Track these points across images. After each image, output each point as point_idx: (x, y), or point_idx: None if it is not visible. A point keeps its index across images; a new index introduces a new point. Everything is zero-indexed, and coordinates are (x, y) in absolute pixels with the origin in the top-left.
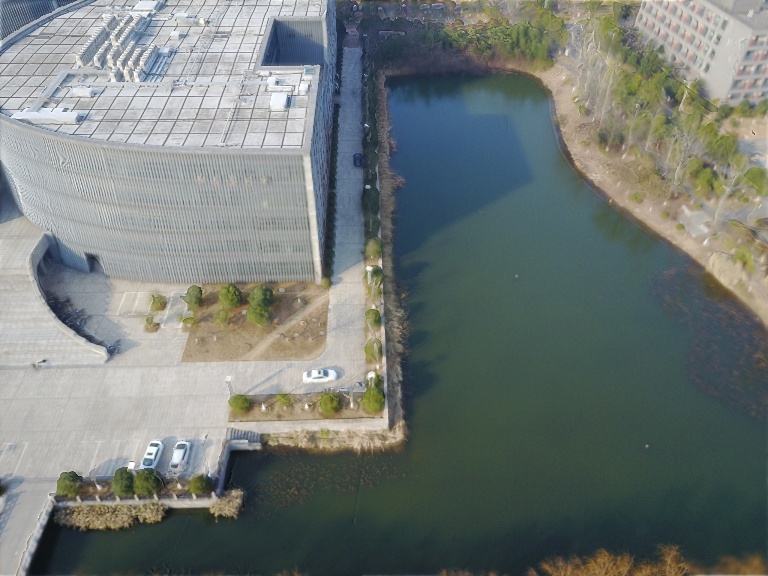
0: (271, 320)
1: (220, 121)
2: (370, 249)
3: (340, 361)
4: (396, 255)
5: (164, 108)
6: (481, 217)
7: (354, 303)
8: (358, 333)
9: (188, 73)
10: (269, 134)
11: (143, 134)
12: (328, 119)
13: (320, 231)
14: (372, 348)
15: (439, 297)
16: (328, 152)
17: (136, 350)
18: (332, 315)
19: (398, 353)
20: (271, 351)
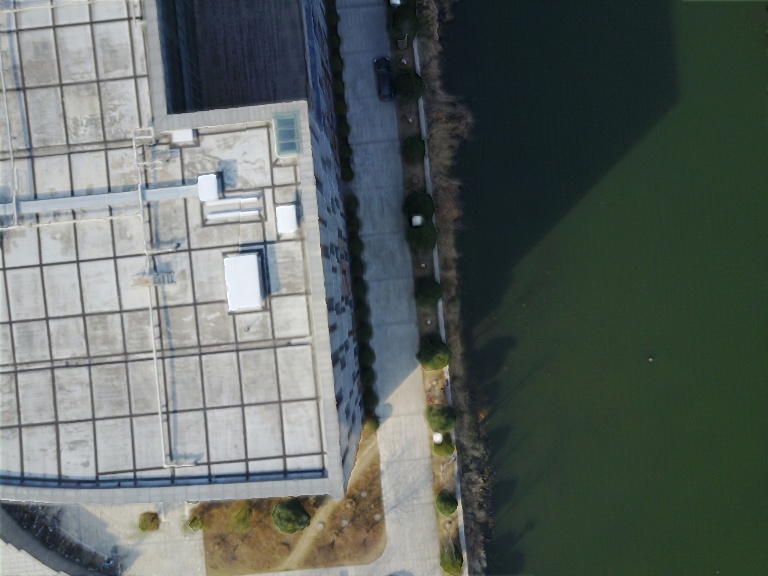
0: (308, 520)
1: (140, 363)
2: (432, 369)
3: (408, 562)
4: (466, 325)
5: (10, 319)
6: (603, 215)
7: (415, 456)
8: (426, 512)
9: (7, 146)
10: (250, 411)
11: (6, 429)
12: (319, 31)
13: (355, 388)
14: (451, 572)
15: (533, 414)
16: (330, 105)
17: (143, 562)
18: (387, 483)
19: (479, 525)
20: (317, 554)
